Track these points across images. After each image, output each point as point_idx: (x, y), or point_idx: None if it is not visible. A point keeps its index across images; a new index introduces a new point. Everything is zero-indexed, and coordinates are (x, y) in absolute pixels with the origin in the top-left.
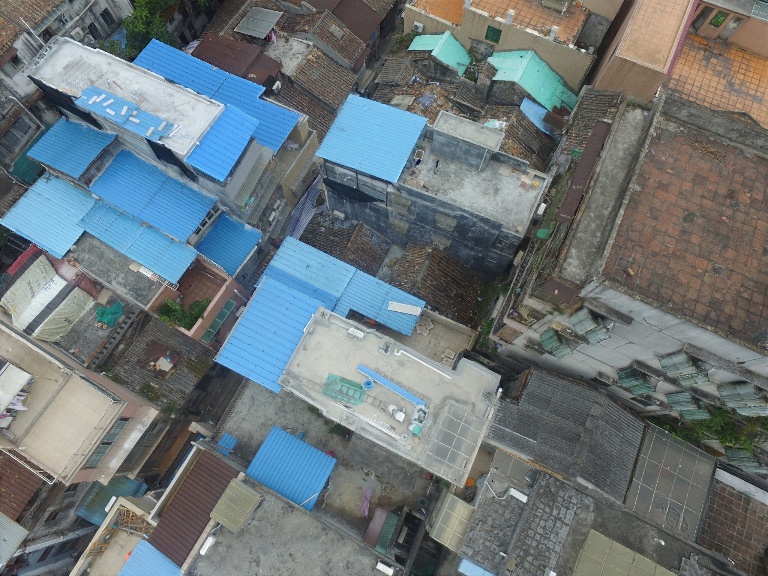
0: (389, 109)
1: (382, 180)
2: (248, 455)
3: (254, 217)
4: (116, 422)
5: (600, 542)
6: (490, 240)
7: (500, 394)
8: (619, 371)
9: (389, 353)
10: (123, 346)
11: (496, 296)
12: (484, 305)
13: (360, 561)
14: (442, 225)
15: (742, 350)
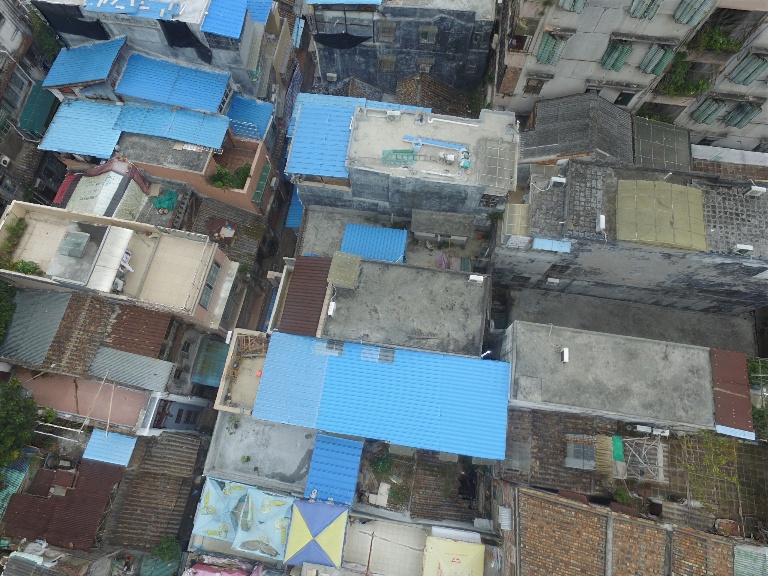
0: None
1: (367, 10)
2: None
3: (262, 91)
4: (212, 265)
5: (628, 185)
6: (468, 38)
7: None
8: (601, 61)
9: (424, 122)
10: (185, 229)
11: (483, 96)
12: (476, 108)
13: (455, 284)
14: (426, 38)
15: None
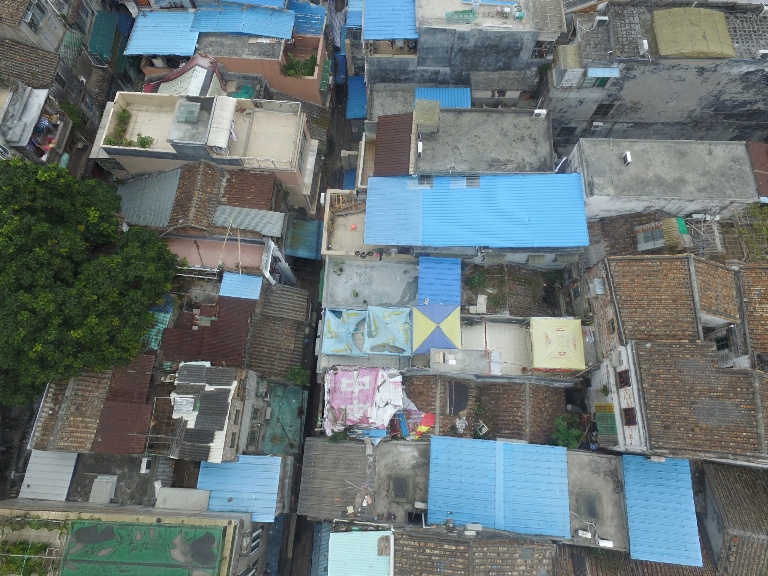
0: None
1: None
2: None
3: None
4: None
5: (662, 14)
6: None
7: None
8: None
9: None
10: None
11: None
12: None
13: (521, 121)
14: None
15: None
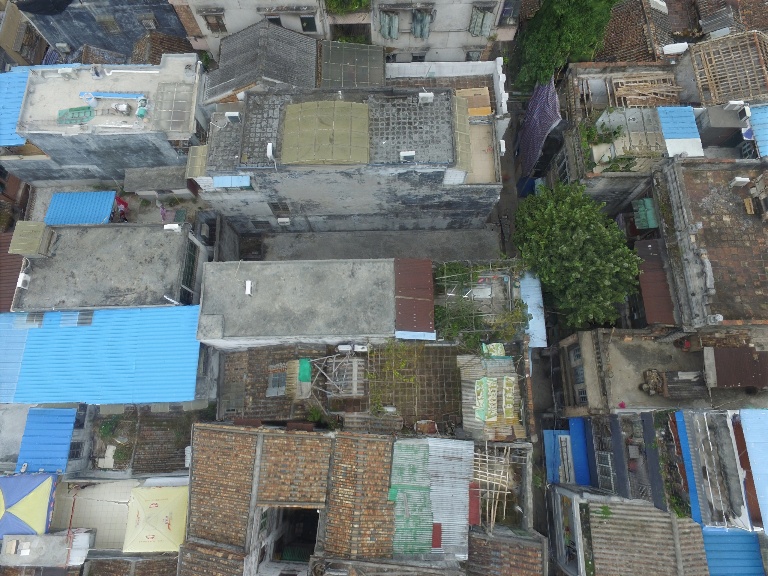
0: None
1: None
2: None
3: None
4: None
5: (294, 109)
6: None
7: None
8: None
9: (101, 76)
10: None
11: None
12: None
13: (154, 236)
14: None
15: None
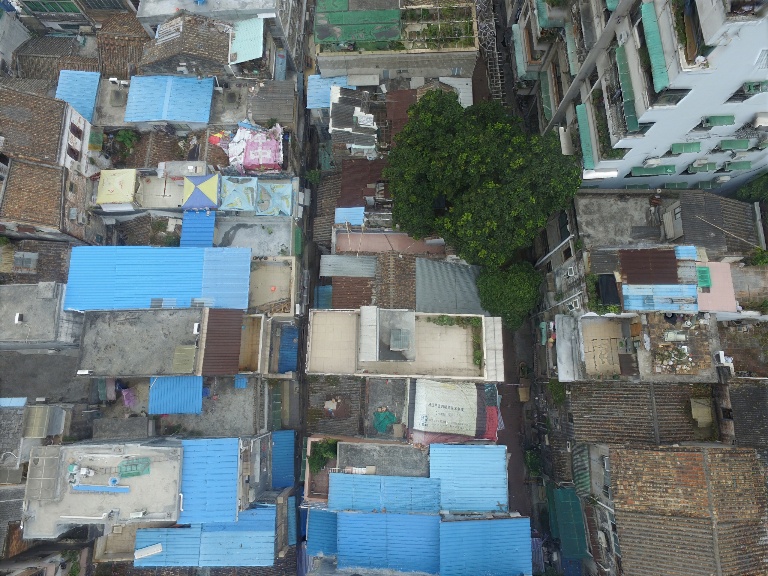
0: None
1: None
2: (229, 381)
3: None
4: None
5: None
6: None
7: None
8: None
9: None
10: None
11: None
12: None
13: (104, 367)
14: None
15: None
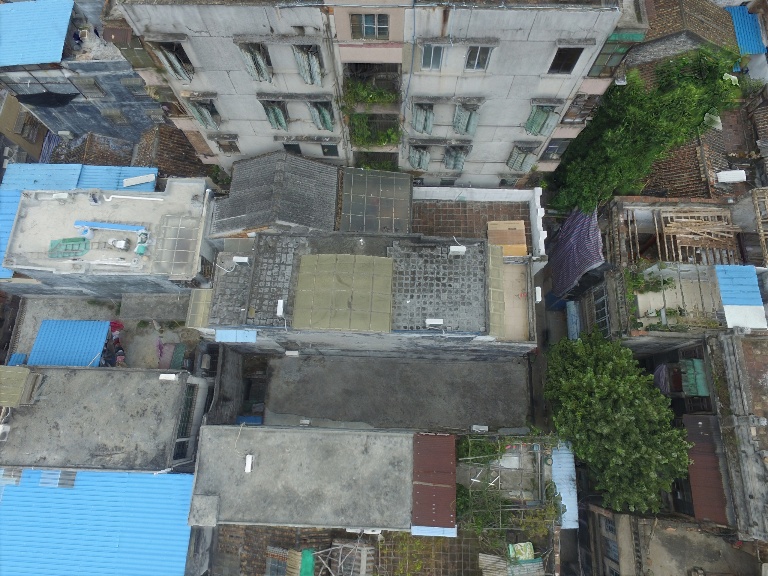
0: (36, 3)
1: (54, 68)
2: None
3: None
4: None
5: (310, 260)
6: None
7: (216, 198)
8: None
9: (100, 202)
10: None
11: None
12: None
13: (149, 384)
14: (134, 90)
15: (251, 12)
